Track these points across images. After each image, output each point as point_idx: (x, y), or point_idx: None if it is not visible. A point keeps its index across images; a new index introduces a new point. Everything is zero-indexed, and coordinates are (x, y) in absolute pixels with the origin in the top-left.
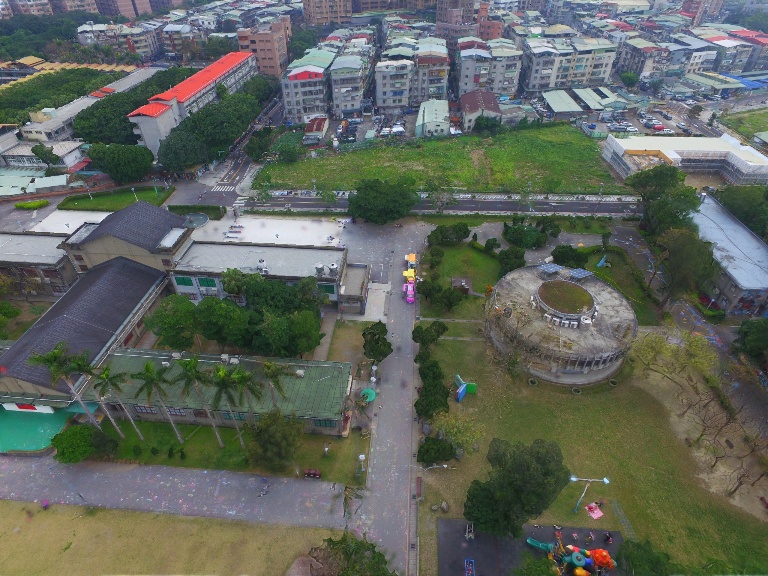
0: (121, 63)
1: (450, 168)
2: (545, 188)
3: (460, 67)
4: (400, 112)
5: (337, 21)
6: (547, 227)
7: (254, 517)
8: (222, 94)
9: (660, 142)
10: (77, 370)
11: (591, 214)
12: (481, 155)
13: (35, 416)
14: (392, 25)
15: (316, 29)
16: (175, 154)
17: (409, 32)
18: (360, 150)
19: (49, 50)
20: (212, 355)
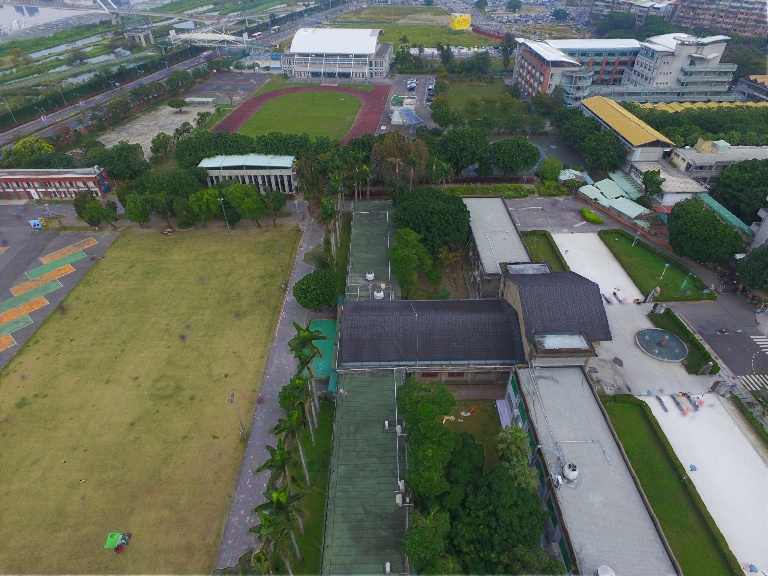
0: None
1: None
2: None
3: None
4: None
5: None
6: None
7: None
8: None
9: None
10: None
11: None
12: None
13: None
14: None
15: None
16: (766, 266)
17: None
18: None
19: None
20: None
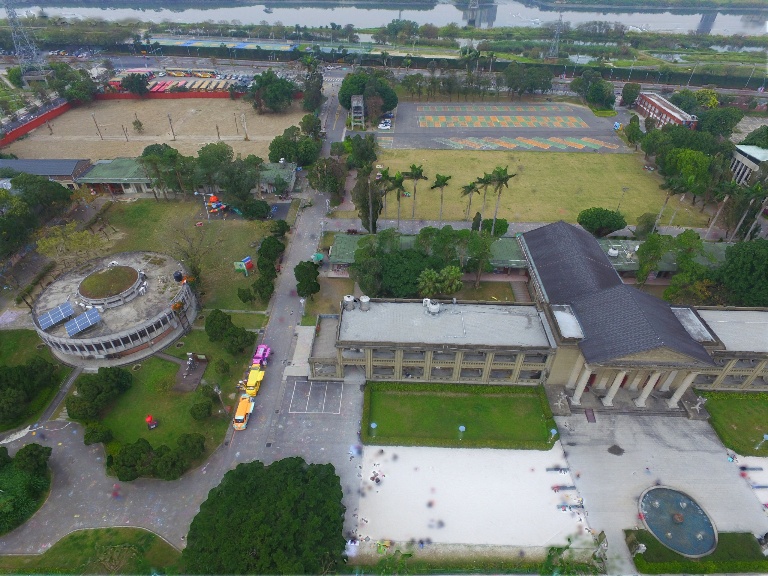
0: None
1: None
2: None
3: None
4: None
5: None
6: None
7: (380, 220)
8: None
9: None
10: None
11: None
12: None
13: None
14: None
15: None
16: None
17: None
18: None
19: None
20: None
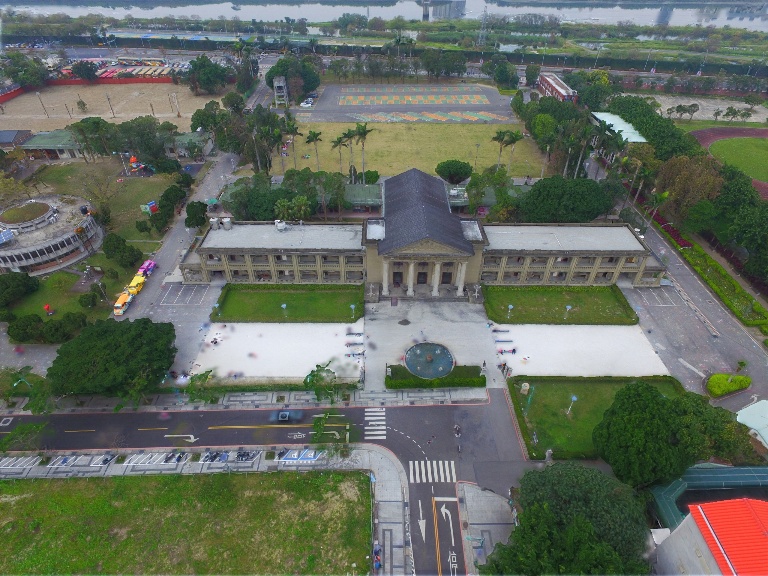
0: None
1: None
2: None
3: None
4: None
5: None
6: None
7: (277, 176)
8: None
9: None
10: None
11: None
12: None
13: None
14: None
15: None
16: None
17: None
18: None
19: None
20: None
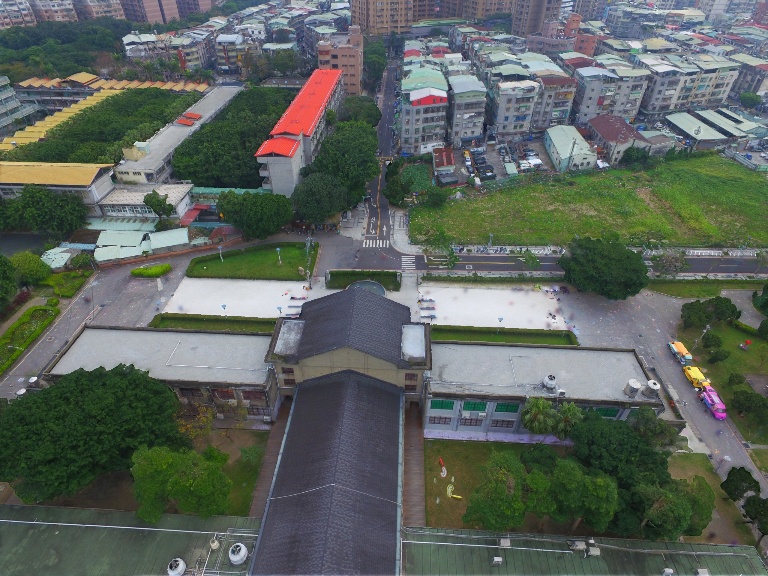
0: (189, 81)
1: (630, 213)
2: None
3: (582, 88)
4: (520, 139)
5: (397, 31)
6: None
7: None
8: (332, 121)
9: None
10: None
11: None
12: (650, 195)
13: None
14: (472, 37)
15: (376, 40)
16: (316, 202)
17: (501, 46)
18: (507, 189)
19: (99, 65)
20: (550, 538)
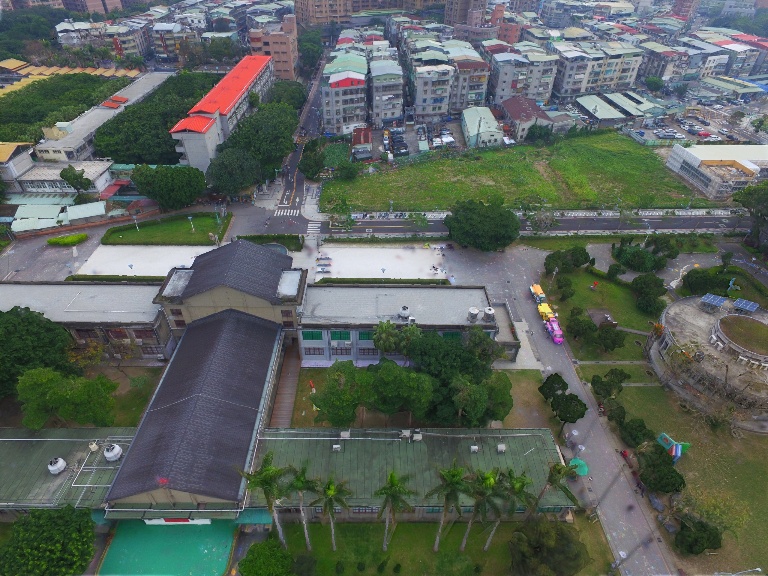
0: (121, 67)
1: (524, 182)
2: (640, 204)
3: (497, 72)
4: (439, 120)
5: (337, 21)
6: (664, 248)
7: None
8: (255, 103)
9: (726, 151)
10: (297, 488)
11: (690, 230)
12: (546, 167)
13: (188, 530)
14: (404, 26)
15: None
16: (229, 175)
17: (429, 34)
18: (418, 164)
19: (29, 52)
20: (385, 430)
